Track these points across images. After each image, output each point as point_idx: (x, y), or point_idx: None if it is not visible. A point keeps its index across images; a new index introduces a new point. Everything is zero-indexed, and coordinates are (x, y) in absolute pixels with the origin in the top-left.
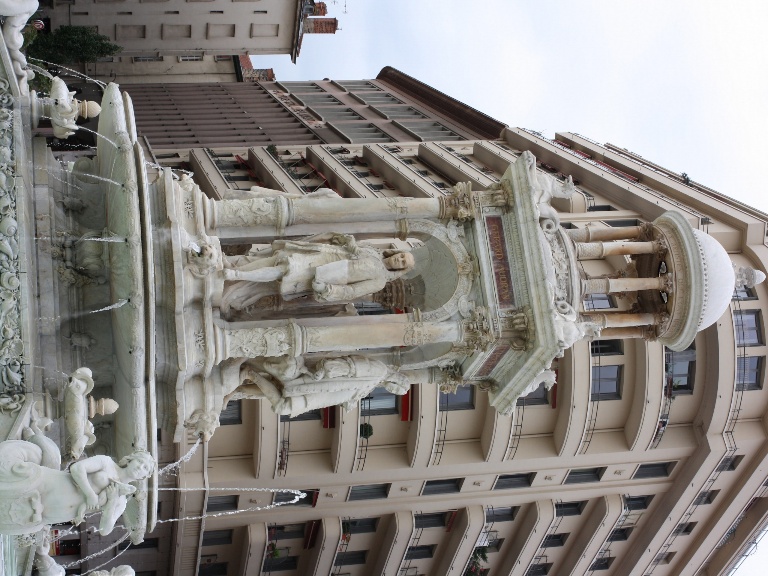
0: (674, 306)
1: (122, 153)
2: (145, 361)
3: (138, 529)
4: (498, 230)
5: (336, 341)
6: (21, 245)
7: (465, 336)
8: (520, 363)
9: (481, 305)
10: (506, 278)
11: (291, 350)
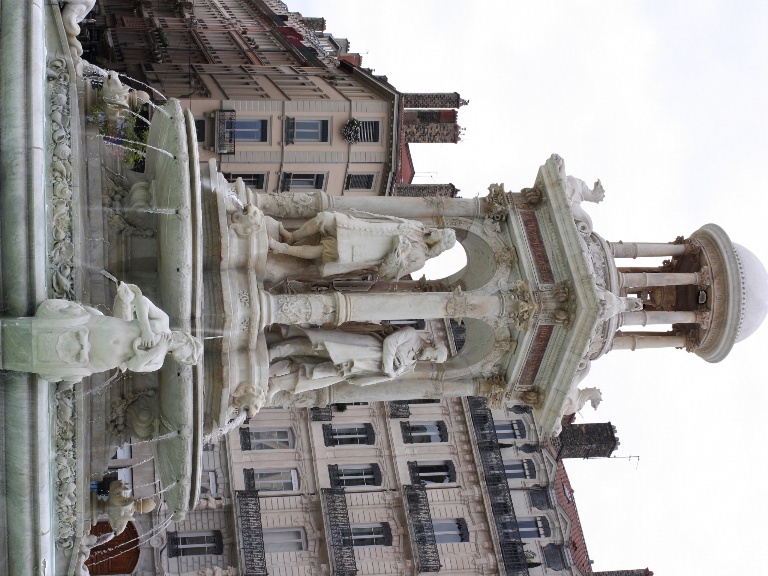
0: None
1: None
2: None
3: None
4: None
5: None
6: None
7: None
8: (553, 219)
9: None
10: None
11: (317, 194)
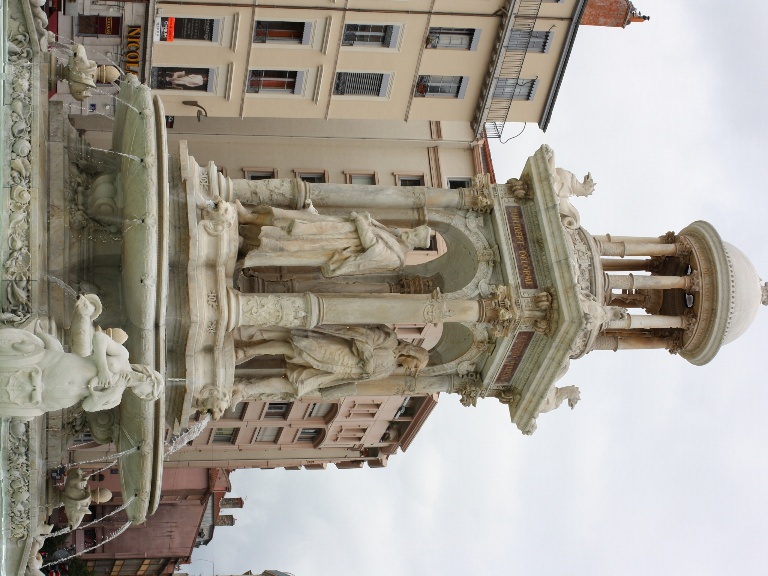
0: None
1: (140, 457)
2: None
3: None
4: (526, 340)
5: None
6: (32, 504)
7: None
8: None
9: (480, 368)
10: (512, 368)
11: None
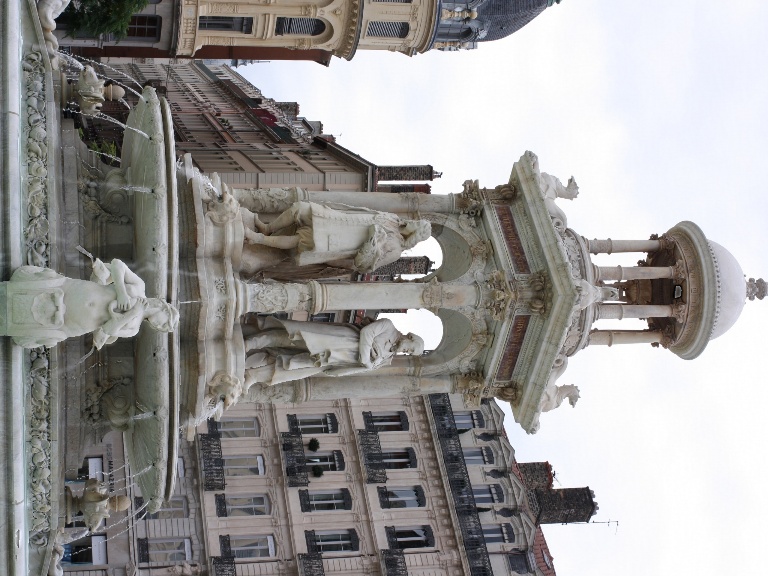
0: None
1: None
2: None
3: None
4: None
5: None
6: None
7: None
8: (528, 212)
9: None
10: None
11: (292, 189)
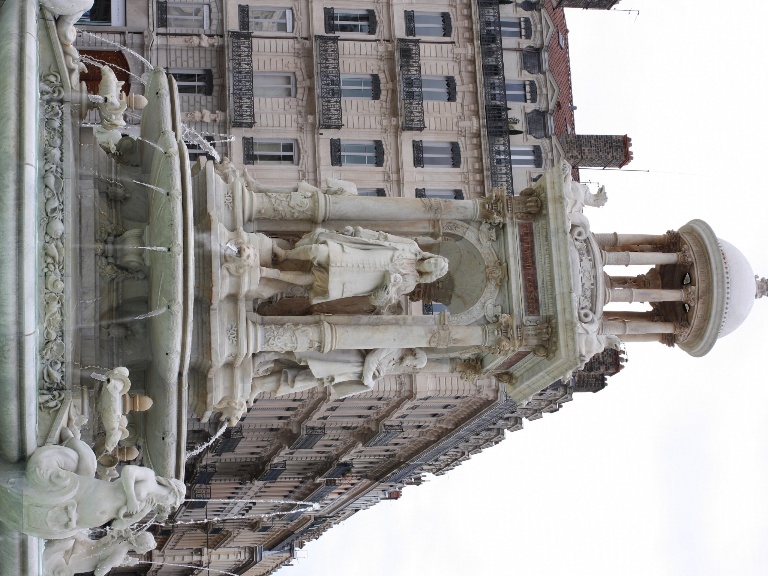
0: (687, 241)
1: None
2: (172, 119)
3: (172, 190)
4: None
5: (356, 196)
6: None
7: (479, 201)
8: (549, 240)
9: None
10: None
11: (314, 196)
